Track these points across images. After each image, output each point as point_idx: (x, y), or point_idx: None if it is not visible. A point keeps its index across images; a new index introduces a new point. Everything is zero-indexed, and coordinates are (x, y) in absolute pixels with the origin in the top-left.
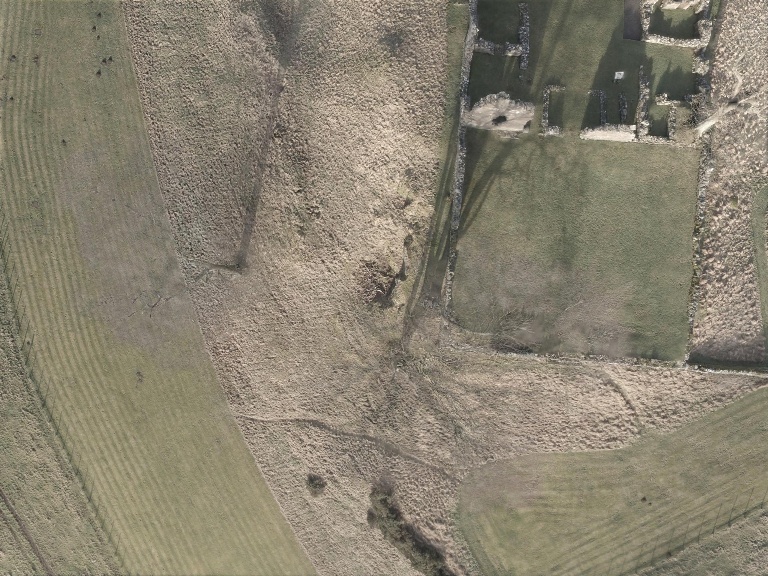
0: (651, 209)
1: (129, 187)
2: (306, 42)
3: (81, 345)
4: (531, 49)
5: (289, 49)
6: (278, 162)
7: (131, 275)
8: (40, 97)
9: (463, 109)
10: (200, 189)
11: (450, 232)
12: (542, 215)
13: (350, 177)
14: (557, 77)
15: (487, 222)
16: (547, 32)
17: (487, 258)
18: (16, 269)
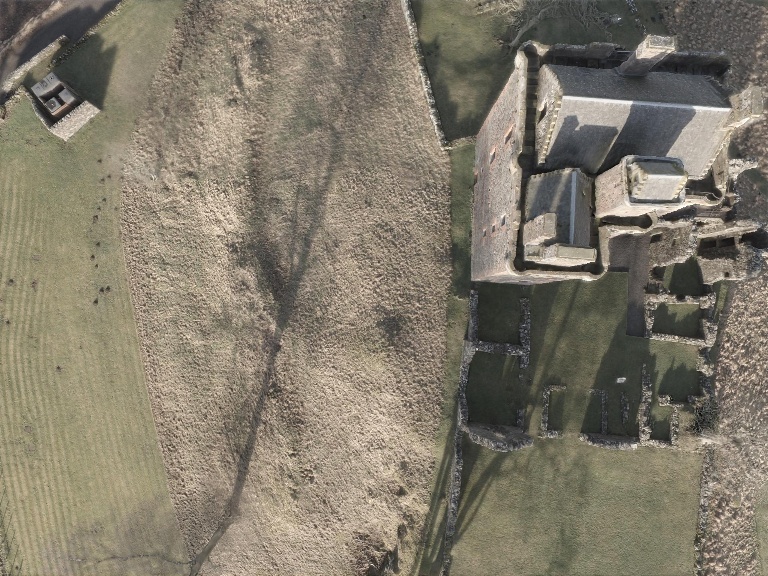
0: (652, 513)
1: (123, 417)
2: (304, 302)
3: (70, 573)
4: (532, 347)
5: (287, 308)
6: (273, 422)
7: (122, 506)
8: (36, 322)
9: (460, 423)
10: (194, 428)
11: (445, 537)
12: (540, 517)
13: (345, 449)
14: (558, 376)
15: (483, 526)
16: (548, 329)
17: (482, 563)
18: (7, 493)
